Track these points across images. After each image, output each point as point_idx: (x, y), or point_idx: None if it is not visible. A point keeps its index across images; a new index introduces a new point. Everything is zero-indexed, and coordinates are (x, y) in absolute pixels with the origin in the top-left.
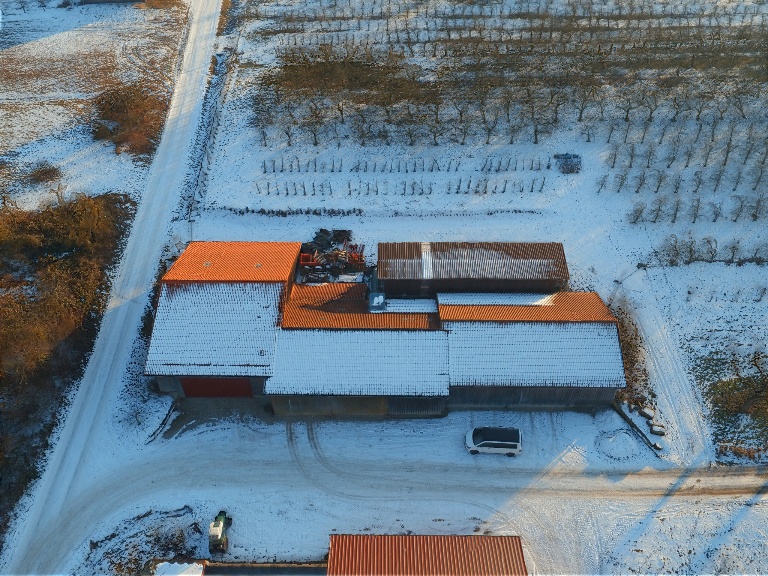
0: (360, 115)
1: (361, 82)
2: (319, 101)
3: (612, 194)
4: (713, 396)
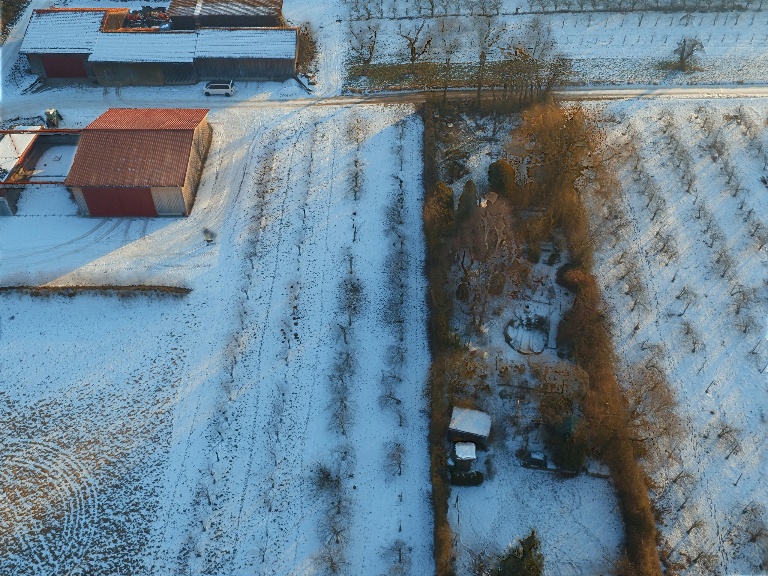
0: None
1: None
2: None
3: None
4: (351, 70)
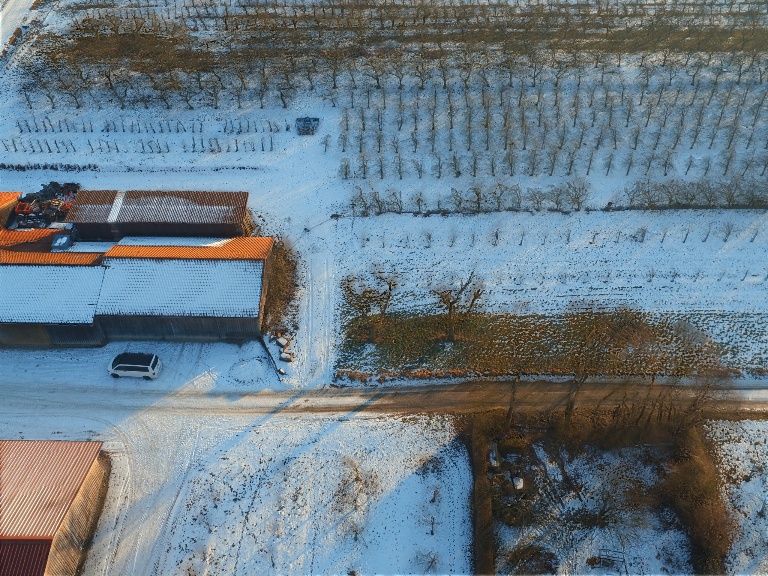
0: (126, 81)
1: (146, 52)
2: (97, 69)
3: (337, 153)
4: (350, 329)
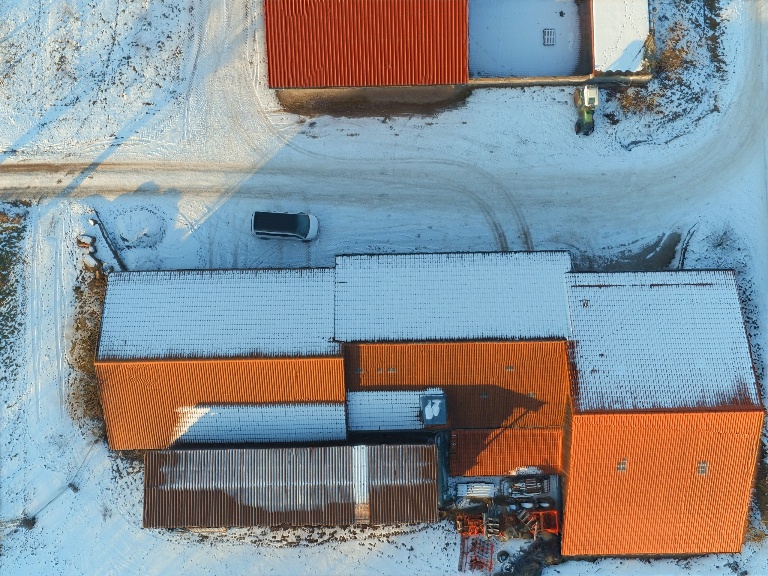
0: None
1: None
2: None
3: None
4: (3, 290)
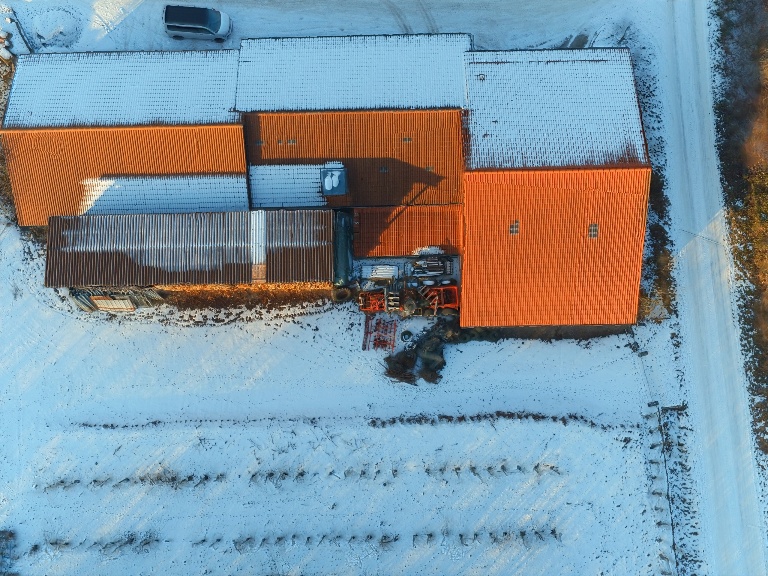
0: None
1: None
2: None
3: None
4: None
